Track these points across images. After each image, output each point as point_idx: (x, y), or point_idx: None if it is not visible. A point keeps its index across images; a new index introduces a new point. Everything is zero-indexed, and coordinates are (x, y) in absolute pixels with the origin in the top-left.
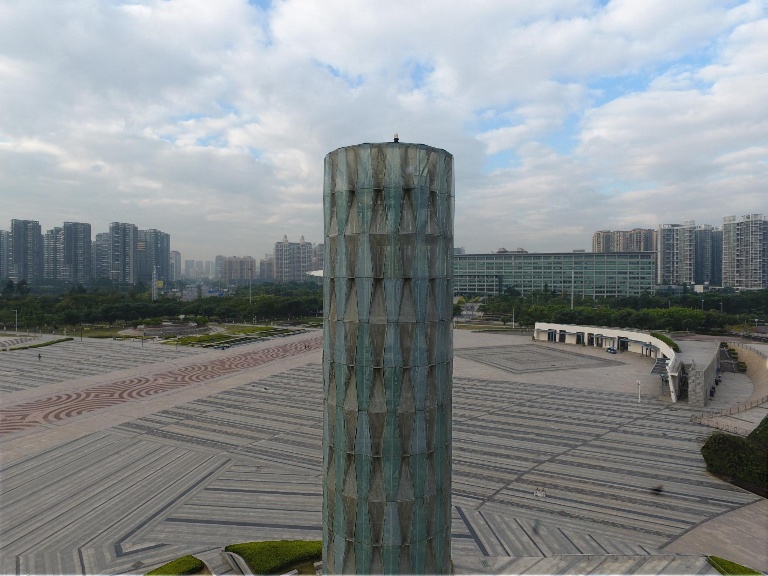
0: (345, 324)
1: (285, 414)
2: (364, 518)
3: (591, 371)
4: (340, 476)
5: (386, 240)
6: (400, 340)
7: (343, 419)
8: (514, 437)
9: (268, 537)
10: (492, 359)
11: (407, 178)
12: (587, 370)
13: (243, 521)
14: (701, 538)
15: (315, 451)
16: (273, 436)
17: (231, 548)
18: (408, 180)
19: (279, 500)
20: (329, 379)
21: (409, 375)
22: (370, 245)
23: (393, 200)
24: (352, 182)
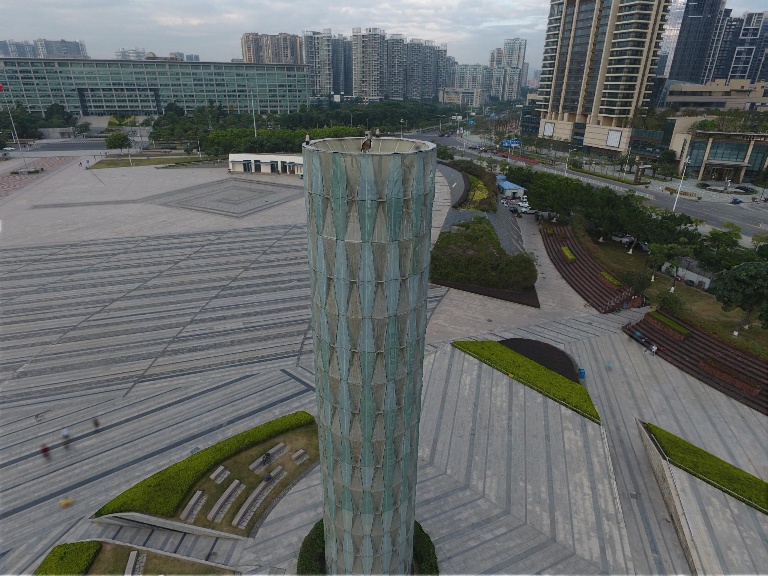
0: (374, 321)
1: (2, 337)
2: (388, 448)
3: (300, 203)
4: (365, 430)
5: (411, 244)
6: (416, 321)
7: (371, 392)
8: (282, 288)
9: (130, 479)
10: (205, 204)
11: (424, 183)
12: (296, 202)
13: (83, 479)
14: (434, 328)
15: (94, 370)
16: (16, 371)
17: (108, 511)
18: (425, 186)
19: (104, 439)
20: (349, 365)
21: (418, 342)
22: (399, 251)
23: (414, 206)
24: (378, 191)
